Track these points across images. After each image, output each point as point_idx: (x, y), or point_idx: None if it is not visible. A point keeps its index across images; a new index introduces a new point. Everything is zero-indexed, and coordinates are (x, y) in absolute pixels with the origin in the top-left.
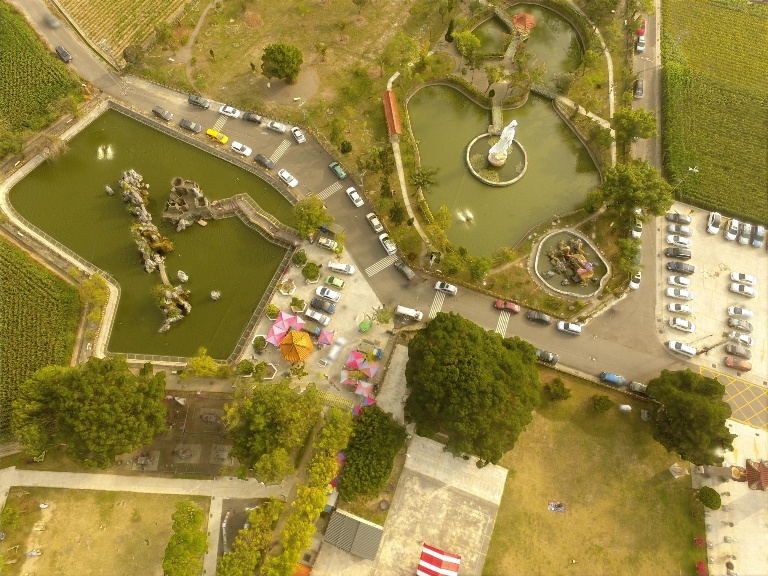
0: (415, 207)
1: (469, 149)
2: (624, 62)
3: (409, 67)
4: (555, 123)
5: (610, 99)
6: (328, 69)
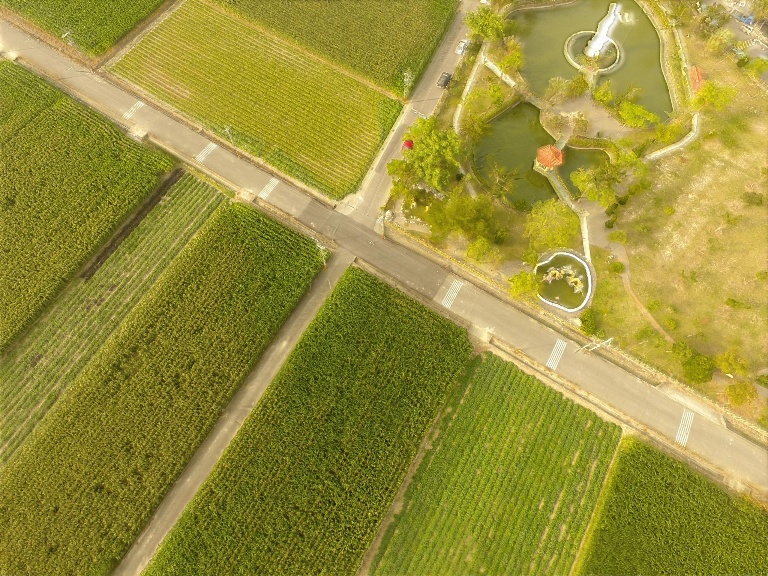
0: (667, 26)
1: (617, 61)
2: (442, 113)
3: (696, 96)
4: (529, 74)
5: (472, 81)
6: (763, 153)
